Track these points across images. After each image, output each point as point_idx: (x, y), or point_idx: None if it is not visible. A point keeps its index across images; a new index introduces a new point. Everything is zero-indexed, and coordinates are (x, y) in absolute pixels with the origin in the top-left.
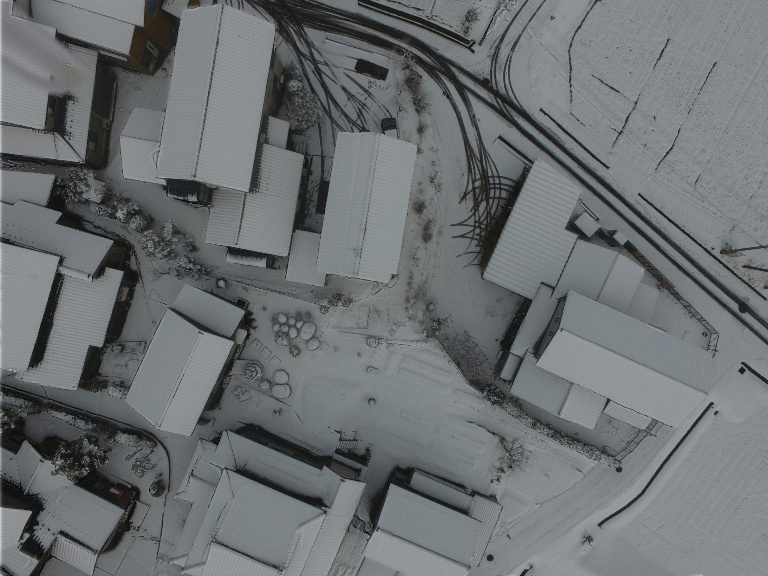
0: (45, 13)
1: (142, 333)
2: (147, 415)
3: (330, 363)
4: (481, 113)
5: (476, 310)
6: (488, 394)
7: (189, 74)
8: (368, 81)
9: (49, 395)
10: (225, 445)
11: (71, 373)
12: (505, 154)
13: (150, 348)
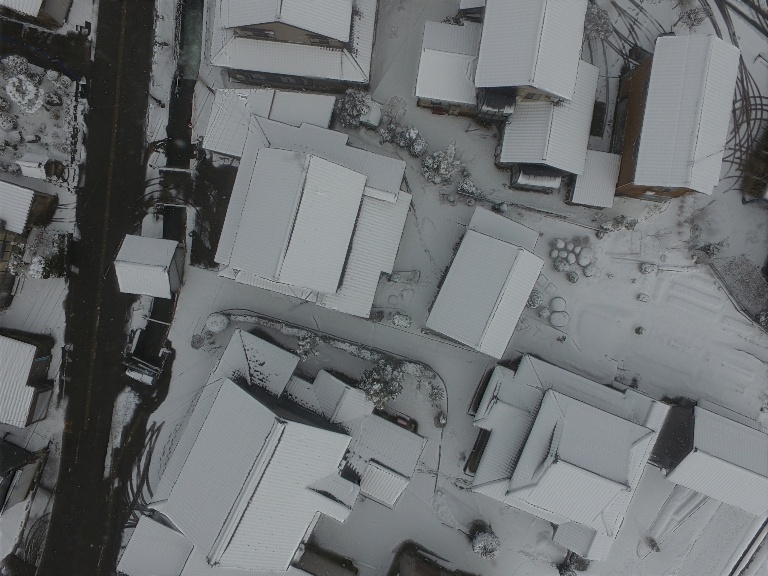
0: None
1: (416, 262)
2: (461, 337)
3: (603, 290)
4: (742, 30)
5: (736, 236)
6: (767, 318)
7: None
8: None
9: (321, 328)
10: (528, 370)
11: (365, 300)
12: (765, 73)
13: (452, 271)
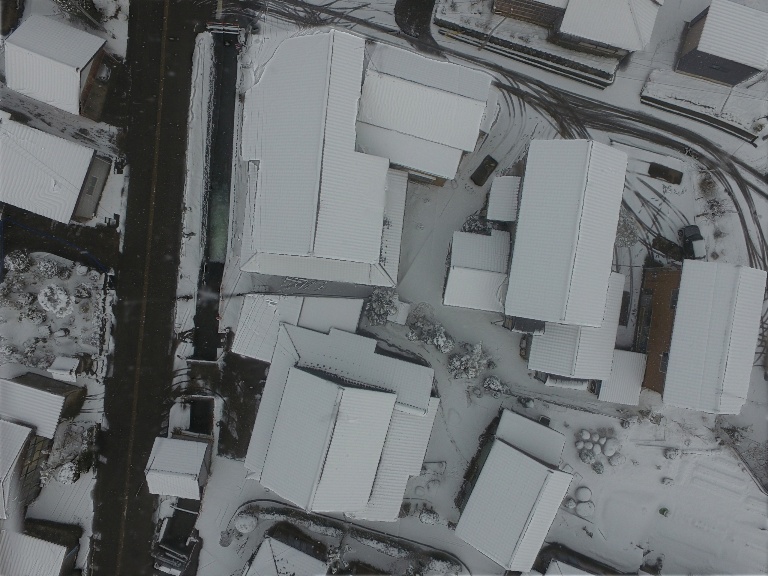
0: (369, 140)
1: (442, 453)
2: (491, 554)
3: (628, 476)
4: (763, 209)
5: (759, 412)
6: None
7: (547, 210)
8: (662, 186)
9: (348, 518)
10: None
11: (394, 505)
12: None
13: (481, 481)
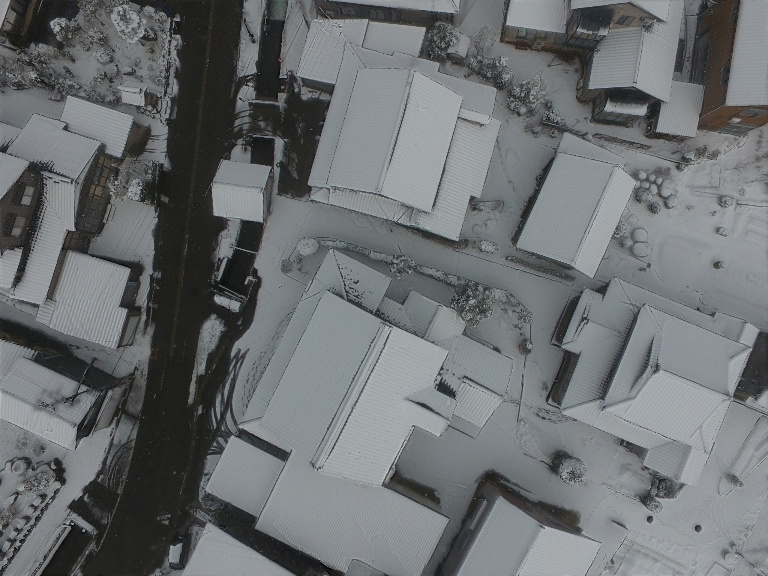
0: None
1: (499, 193)
2: (555, 255)
3: (683, 223)
4: None
5: None
6: None
7: None
8: None
9: None
10: (617, 292)
11: (455, 223)
12: None
13: (543, 192)
